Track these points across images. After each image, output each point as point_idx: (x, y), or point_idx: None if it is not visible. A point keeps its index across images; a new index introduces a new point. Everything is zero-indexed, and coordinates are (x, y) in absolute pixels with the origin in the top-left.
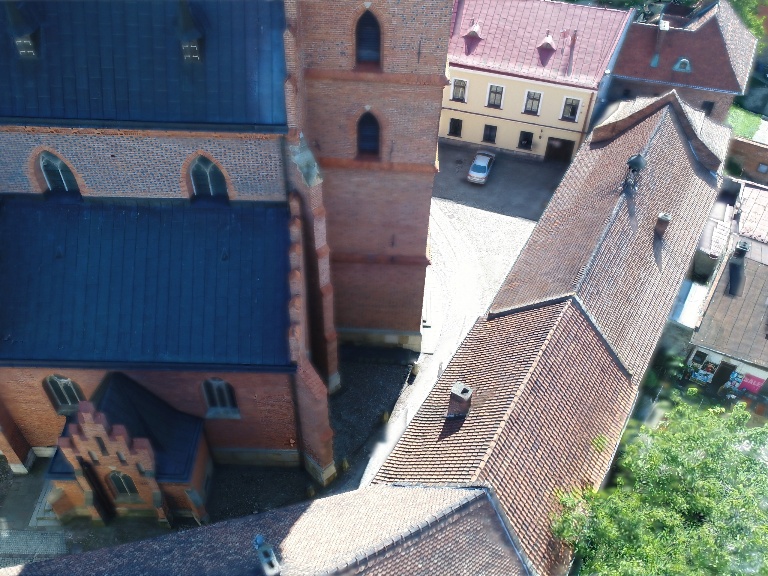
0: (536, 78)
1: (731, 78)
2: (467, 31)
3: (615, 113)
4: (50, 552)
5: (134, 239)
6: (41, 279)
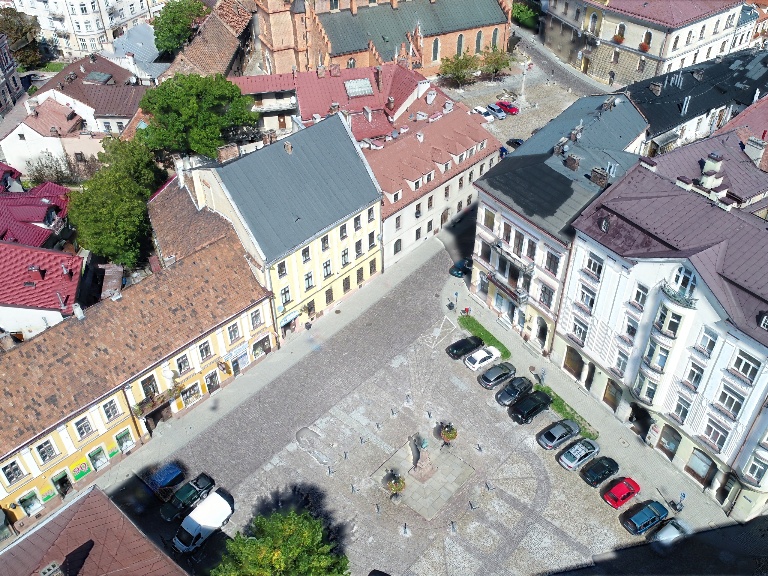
0: None
1: None
2: None
3: None
4: None
5: None
6: None
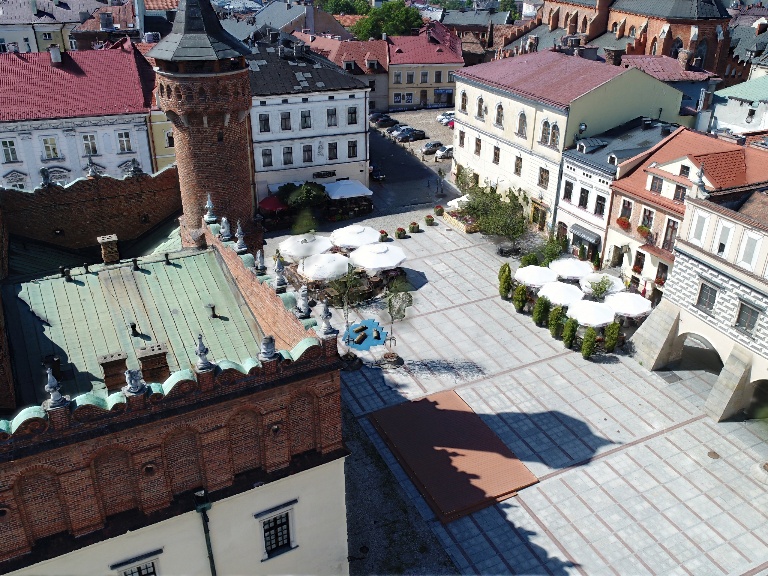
0: None
1: None
2: None
3: None
4: None
5: None
6: None
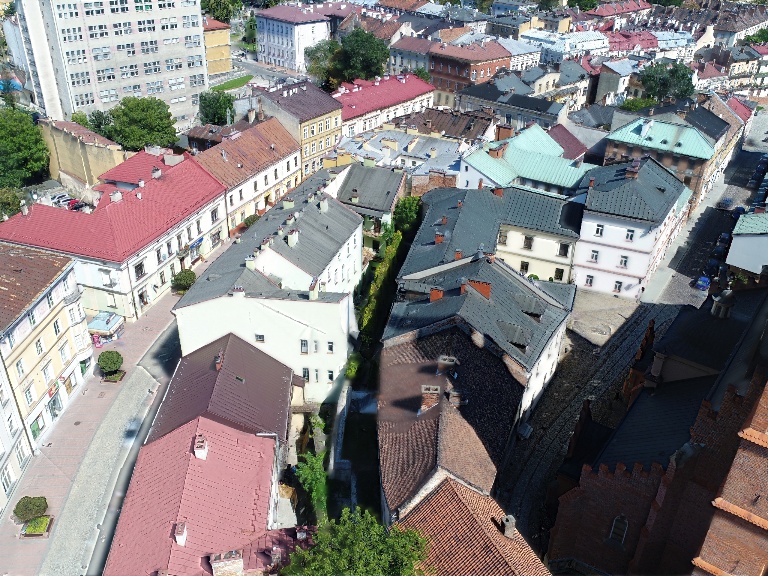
0: None
1: None
2: None
3: None
4: (563, 449)
5: (688, 421)
6: (679, 397)
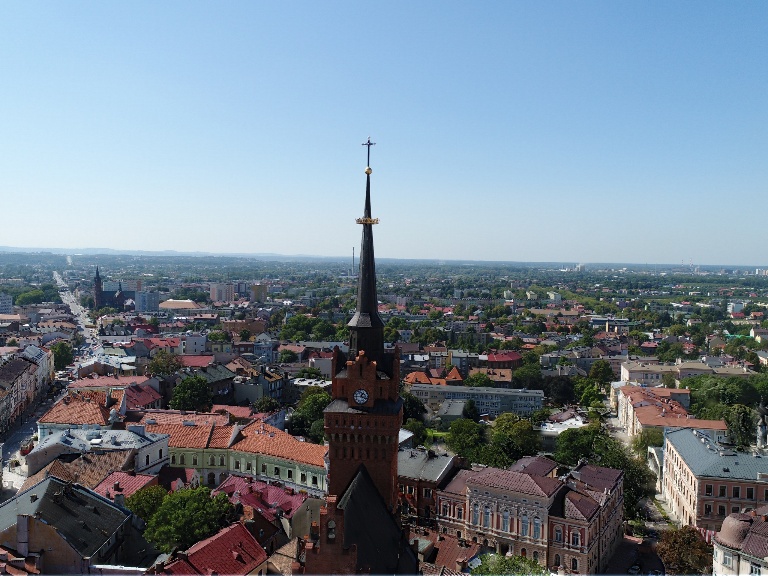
0: (252, 570)
1: (274, 527)
2: (209, 574)
3: (275, 564)
4: None
5: None
6: None
